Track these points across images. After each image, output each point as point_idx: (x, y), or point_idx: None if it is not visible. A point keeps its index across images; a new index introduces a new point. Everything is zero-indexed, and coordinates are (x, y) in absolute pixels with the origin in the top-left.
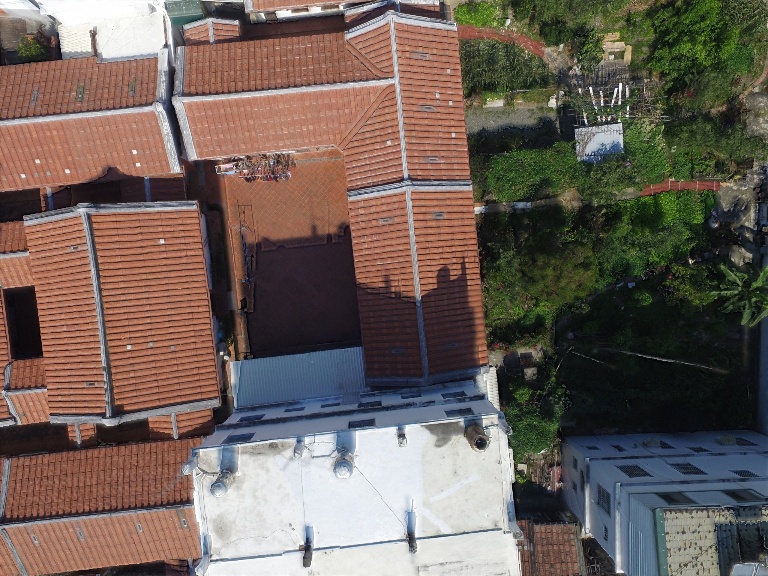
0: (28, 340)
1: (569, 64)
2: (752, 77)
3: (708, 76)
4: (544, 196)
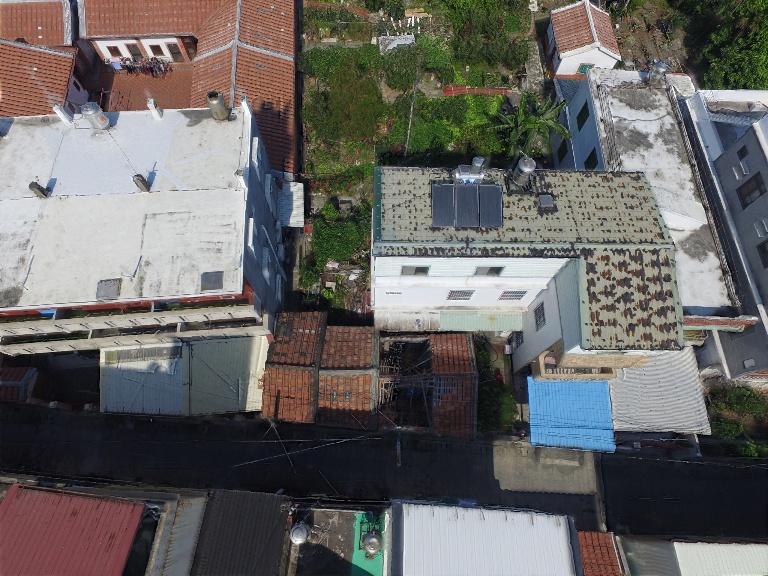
0: None
1: None
2: (522, 32)
3: (472, 7)
4: None
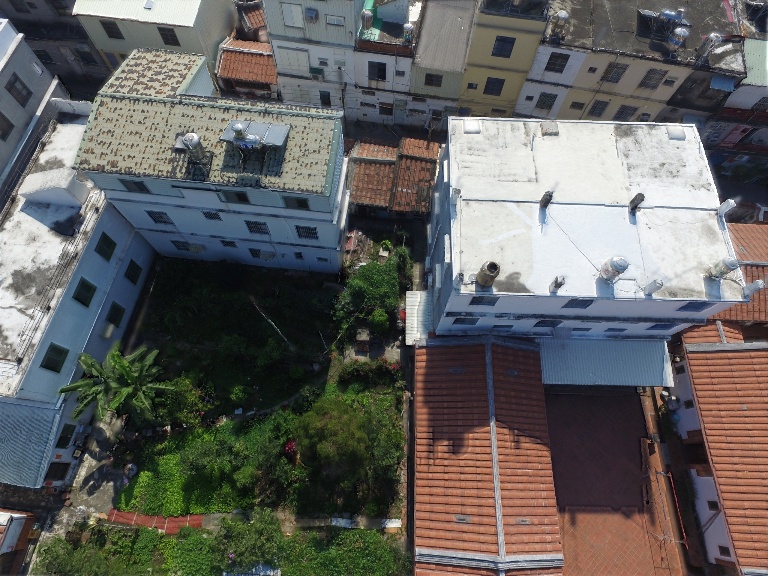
0: None
1: None
2: None
3: None
4: (317, 530)
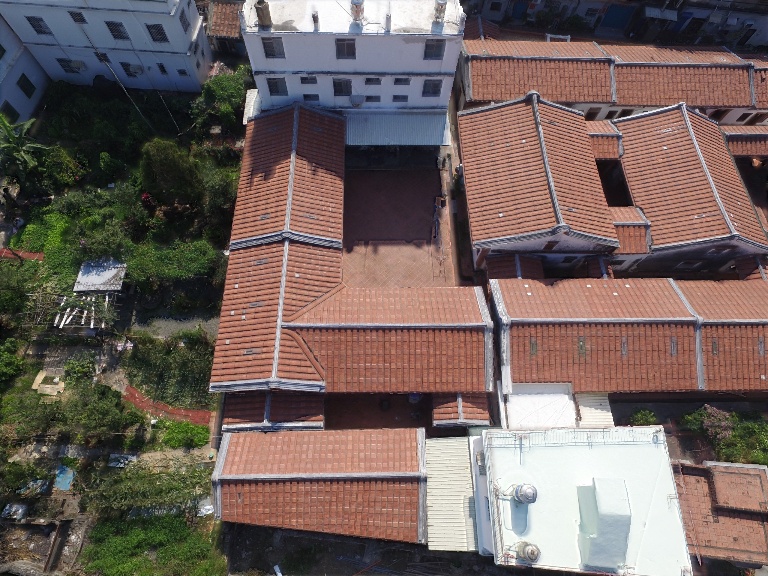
0: (618, 192)
1: (103, 377)
2: None
3: None
4: None
